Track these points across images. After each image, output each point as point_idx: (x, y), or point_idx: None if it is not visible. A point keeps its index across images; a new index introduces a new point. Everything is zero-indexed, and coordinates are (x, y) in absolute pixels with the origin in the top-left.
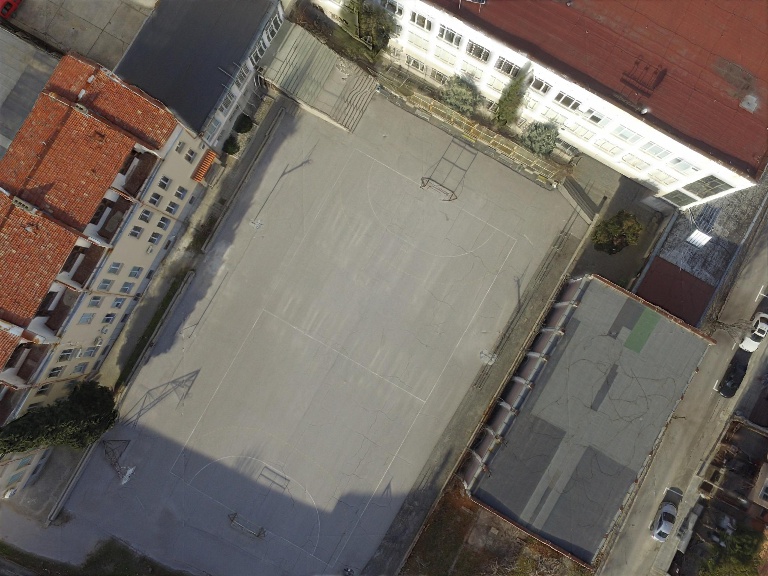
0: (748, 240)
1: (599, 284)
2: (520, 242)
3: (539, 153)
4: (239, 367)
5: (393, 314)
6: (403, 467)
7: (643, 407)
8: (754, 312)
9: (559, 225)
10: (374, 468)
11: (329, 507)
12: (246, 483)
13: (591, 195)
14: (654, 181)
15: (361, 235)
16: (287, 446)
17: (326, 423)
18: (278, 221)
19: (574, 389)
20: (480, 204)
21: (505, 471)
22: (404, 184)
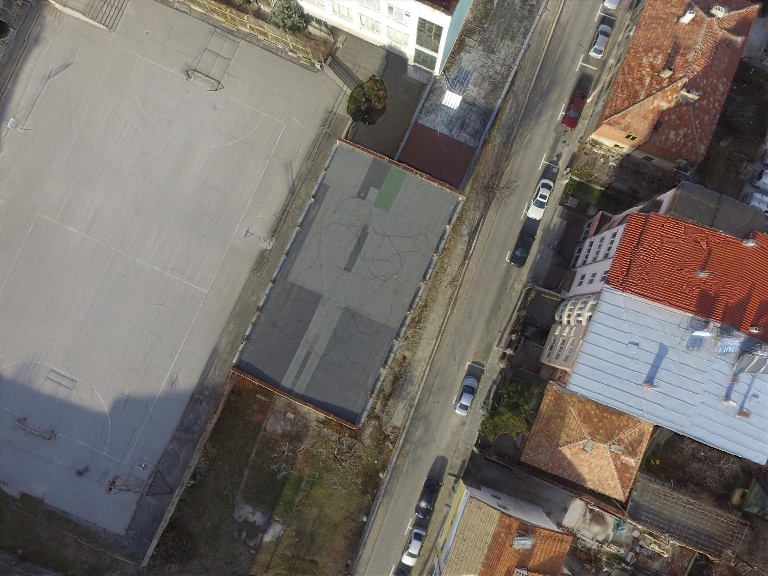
0: (519, 106)
1: (345, 148)
2: (290, 125)
3: (285, 28)
4: (18, 273)
5: (168, 207)
6: (189, 358)
7: (397, 265)
8: (539, 180)
9: (327, 105)
10: (160, 362)
11: (118, 404)
12: (33, 388)
13: (360, 75)
14: (396, 44)
15: (130, 132)
16: (71, 347)
17: (109, 321)
18: (47, 125)
19: (327, 253)
20: (247, 91)
21: (265, 340)
22: (170, 78)
